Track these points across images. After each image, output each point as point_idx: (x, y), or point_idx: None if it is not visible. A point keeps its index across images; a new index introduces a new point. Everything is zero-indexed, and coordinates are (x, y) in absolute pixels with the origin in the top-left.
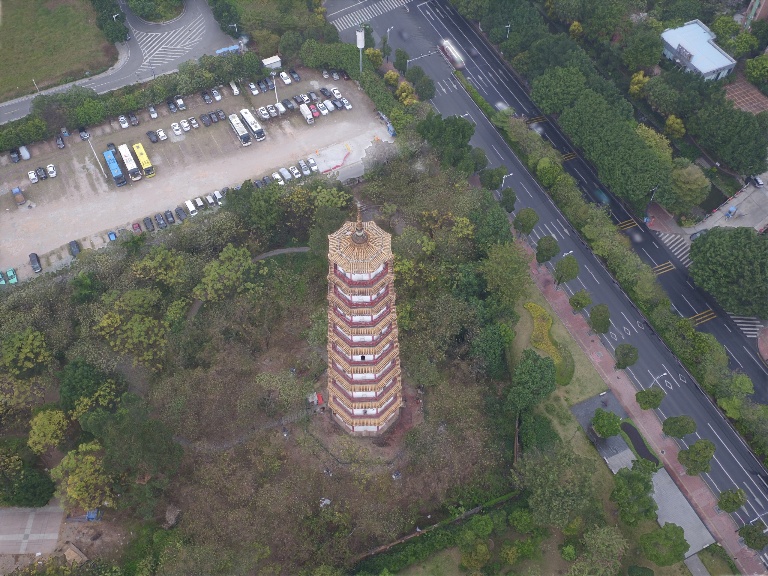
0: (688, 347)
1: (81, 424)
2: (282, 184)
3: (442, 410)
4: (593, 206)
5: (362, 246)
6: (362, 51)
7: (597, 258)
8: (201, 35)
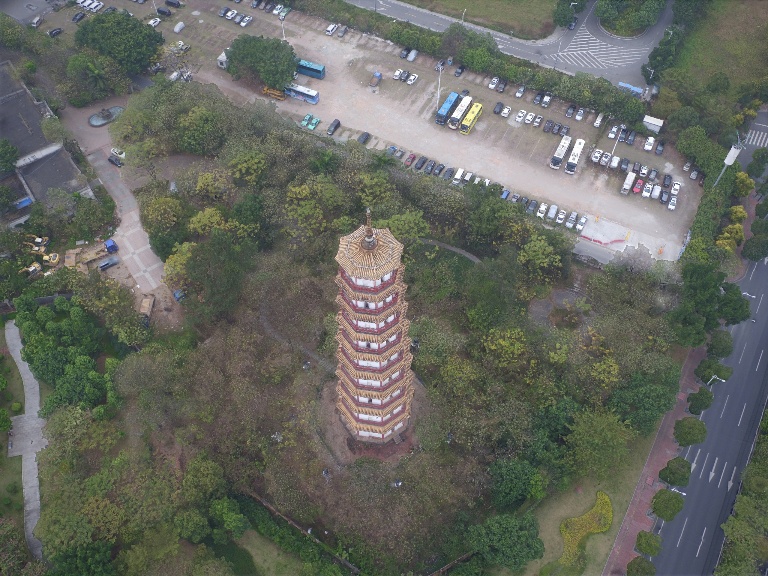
0: None
1: (211, 232)
2: (540, 216)
3: (404, 471)
4: None
5: (363, 251)
6: (735, 170)
7: None
8: (628, 63)
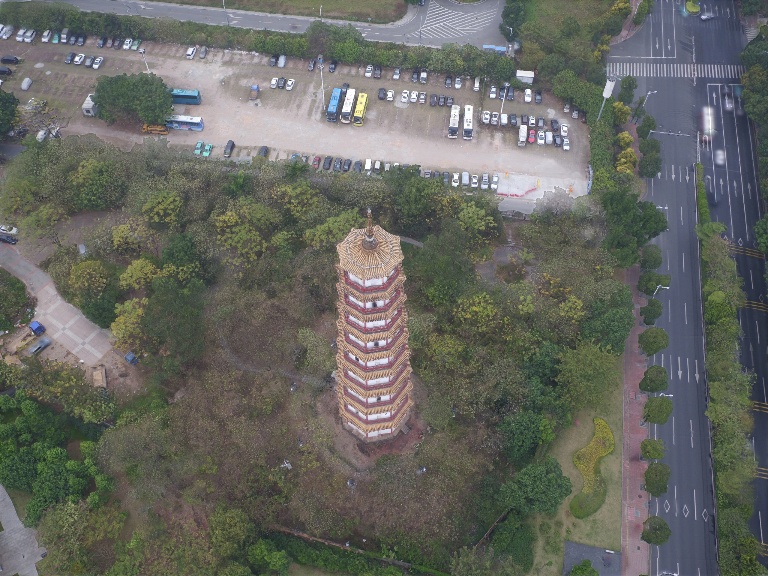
0: (735, 569)
1: (152, 282)
2: (456, 185)
3: (427, 456)
4: (738, 367)
5: (366, 252)
6: (611, 101)
7: (710, 422)
8: (483, 26)
